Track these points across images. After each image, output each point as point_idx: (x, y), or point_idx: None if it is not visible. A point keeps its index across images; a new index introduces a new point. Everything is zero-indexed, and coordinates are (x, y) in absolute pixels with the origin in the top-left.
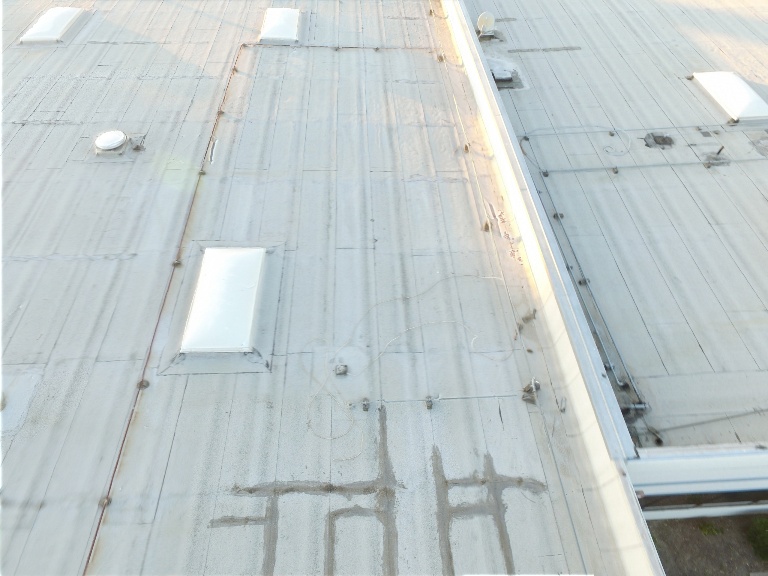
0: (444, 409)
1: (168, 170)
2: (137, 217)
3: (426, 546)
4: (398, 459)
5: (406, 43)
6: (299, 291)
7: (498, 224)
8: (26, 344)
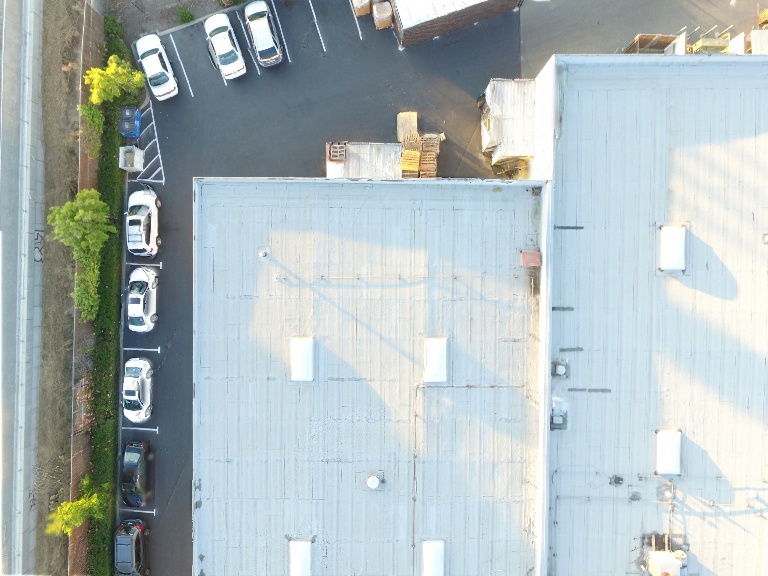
0: None
1: (399, 496)
2: (394, 523)
3: None
4: None
5: (510, 375)
6: (456, 557)
7: (531, 527)
8: (374, 575)
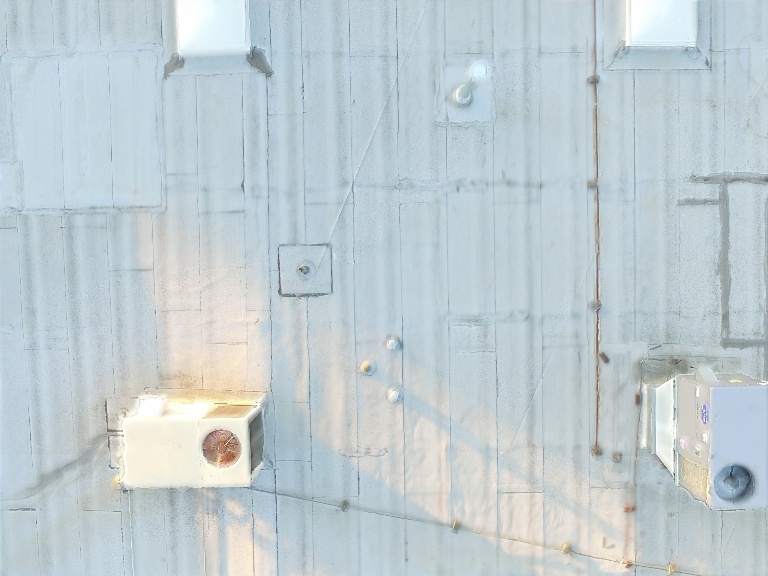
0: None
1: None
2: None
3: None
4: None
5: None
6: None
7: None
8: (463, 31)
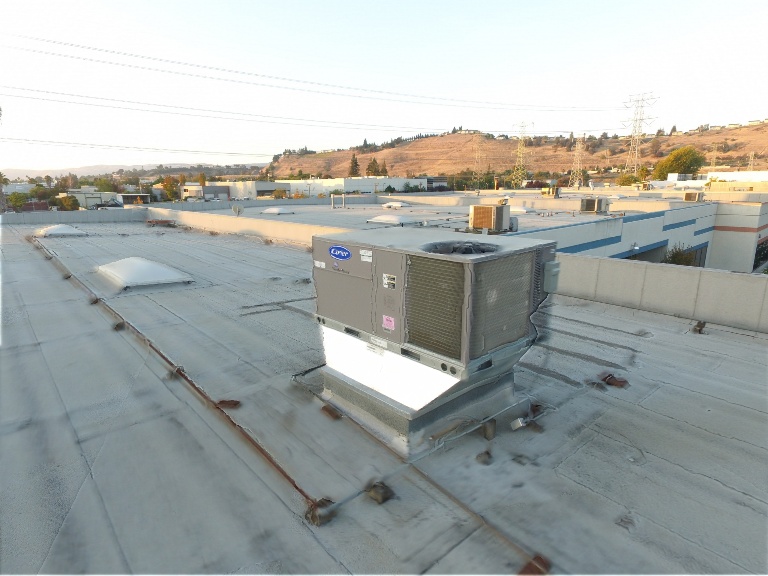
0: None
1: None
2: None
3: None
4: None
5: None
6: (206, 272)
7: None
8: None
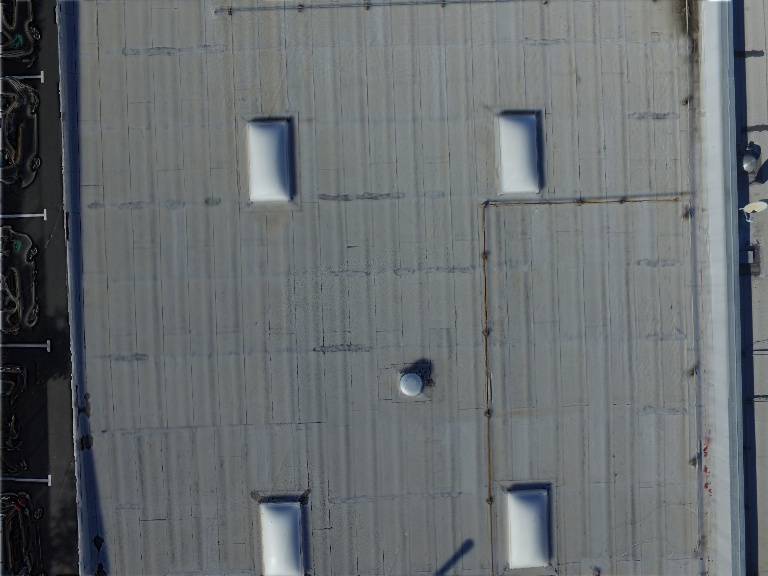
0: None
1: (460, 410)
2: (452, 460)
3: None
4: None
5: (651, 180)
6: (568, 520)
7: (702, 458)
8: (420, 559)
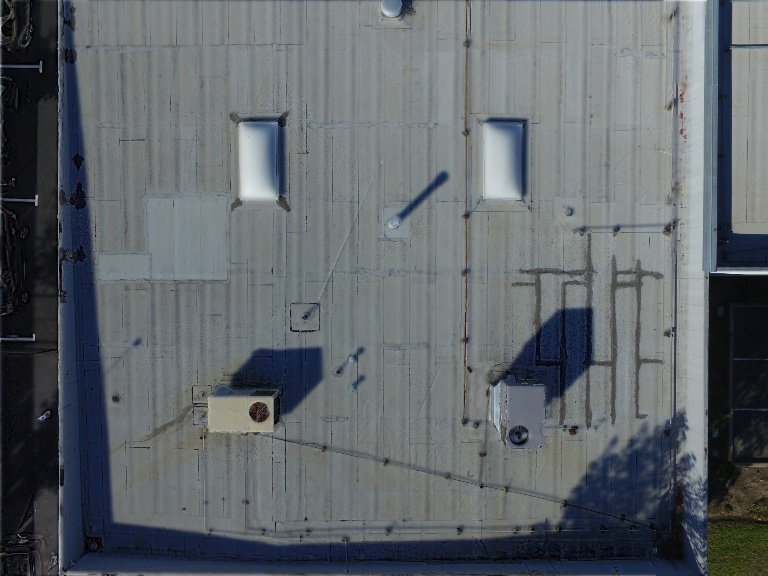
0: (621, 237)
1: (439, 40)
2: (429, 90)
3: (605, 298)
4: (596, 260)
5: None
6: (543, 158)
7: (678, 104)
8: (394, 189)
